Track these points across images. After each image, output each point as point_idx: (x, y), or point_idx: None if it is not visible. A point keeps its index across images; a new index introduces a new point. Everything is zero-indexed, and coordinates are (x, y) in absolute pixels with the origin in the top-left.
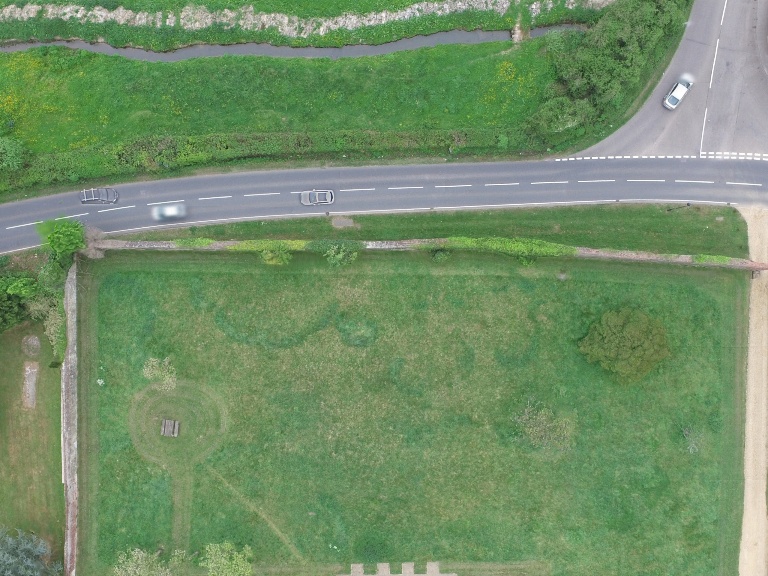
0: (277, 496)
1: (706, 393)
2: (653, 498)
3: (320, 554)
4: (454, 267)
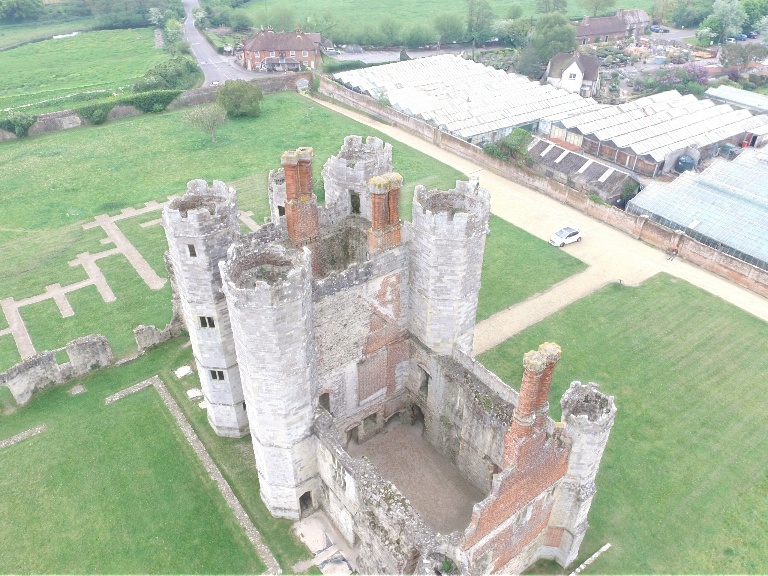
0: (2, 217)
1: (309, 112)
2: (316, 139)
3: (59, 223)
4: (113, 124)
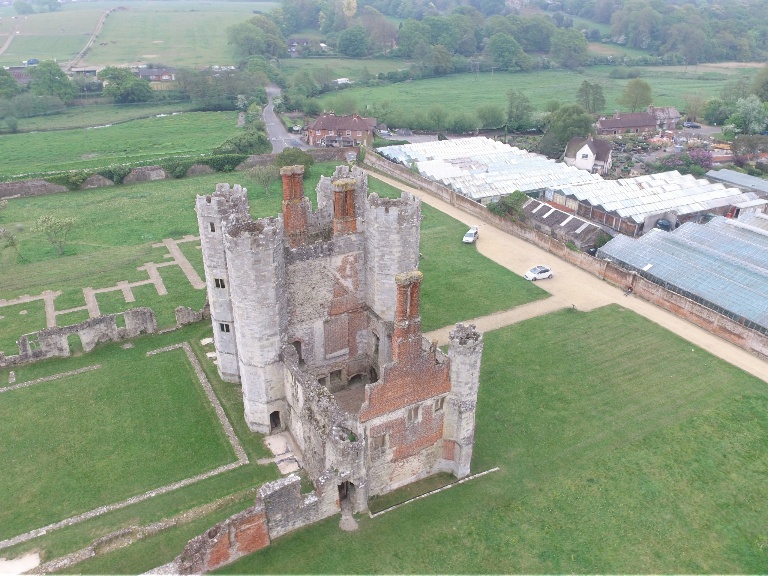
0: None
1: None
2: None
3: None
4: None
